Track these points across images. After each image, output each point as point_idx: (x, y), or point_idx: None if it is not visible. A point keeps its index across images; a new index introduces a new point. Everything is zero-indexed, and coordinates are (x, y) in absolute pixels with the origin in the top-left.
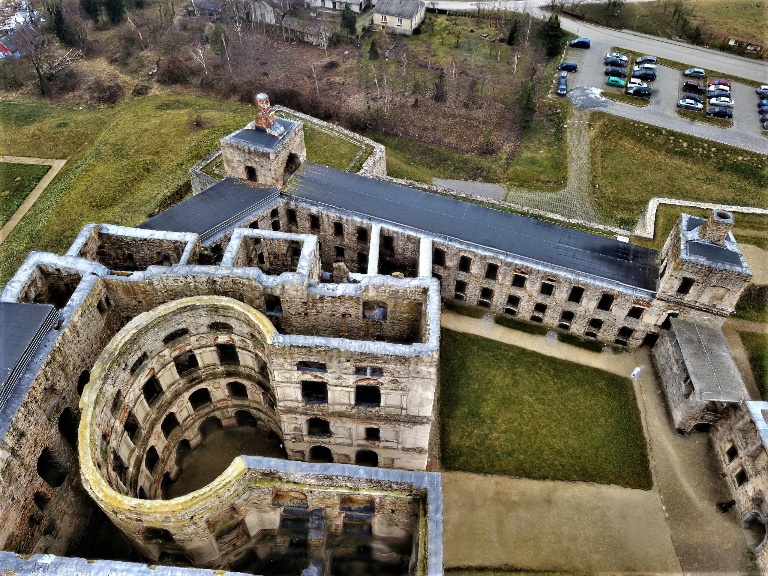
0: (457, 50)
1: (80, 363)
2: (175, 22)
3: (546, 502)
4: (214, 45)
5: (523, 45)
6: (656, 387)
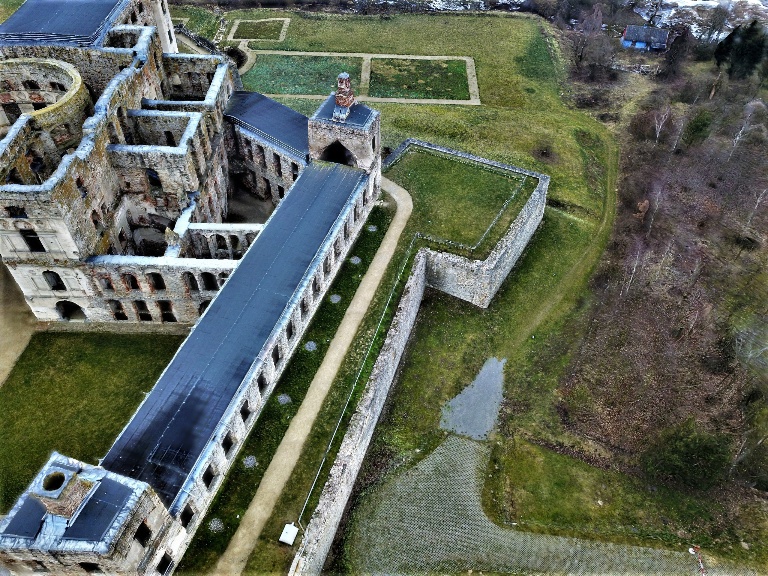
0: None
1: (86, 77)
2: (750, 105)
3: None
4: (686, 128)
5: None
6: None
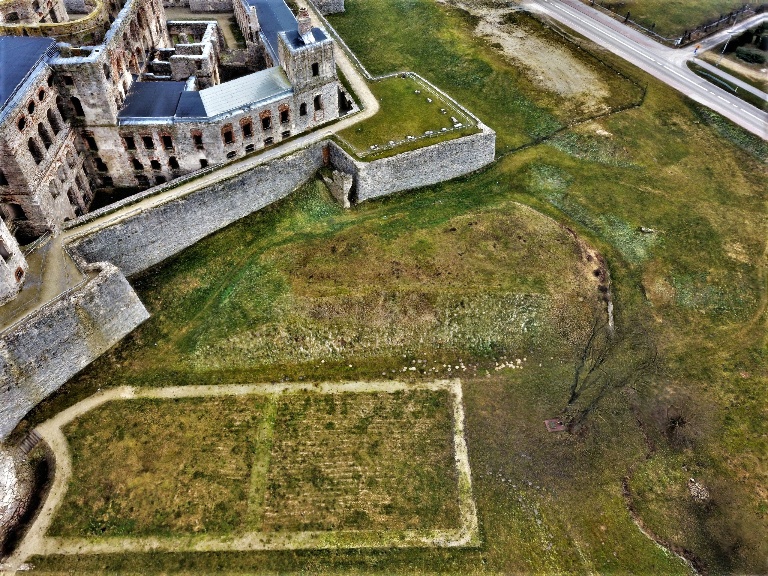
0: None
1: None
2: None
3: None
4: None
5: None
6: (69, 14)
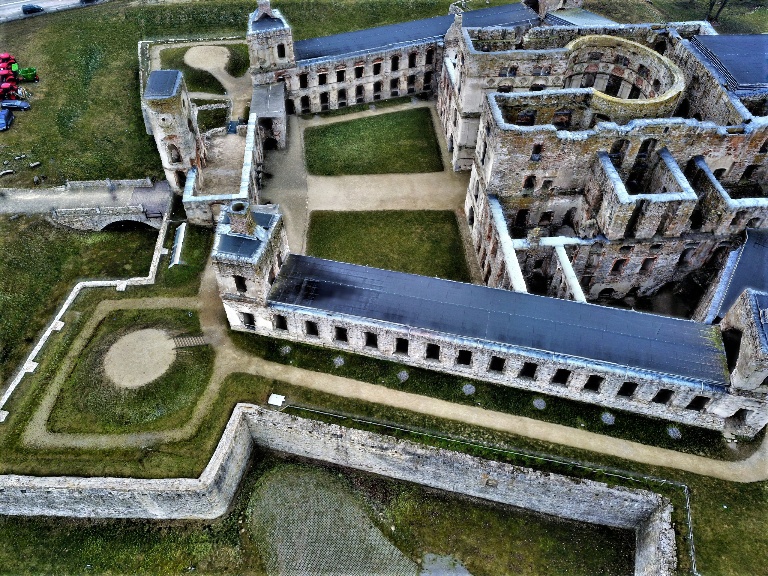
0: None
1: None
2: None
3: (383, 200)
4: None
5: None
6: None
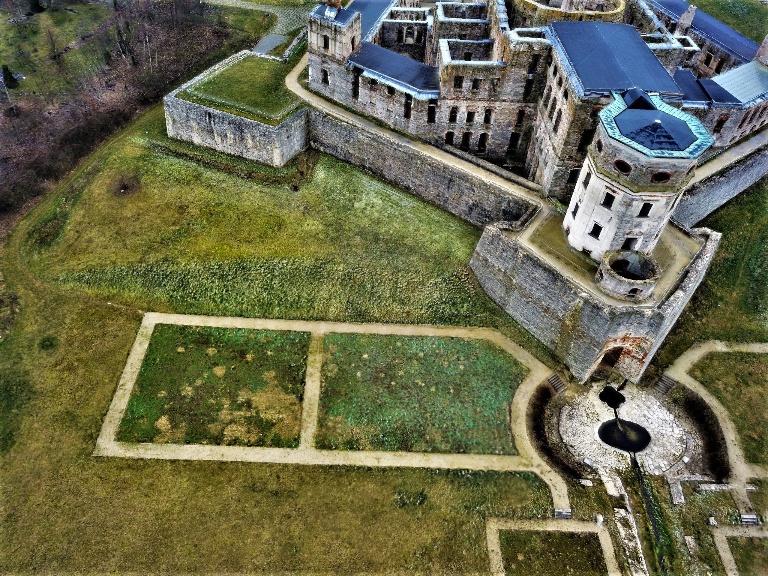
0: (31, 38)
1: None
2: None
3: None
4: None
5: (46, 6)
6: None
